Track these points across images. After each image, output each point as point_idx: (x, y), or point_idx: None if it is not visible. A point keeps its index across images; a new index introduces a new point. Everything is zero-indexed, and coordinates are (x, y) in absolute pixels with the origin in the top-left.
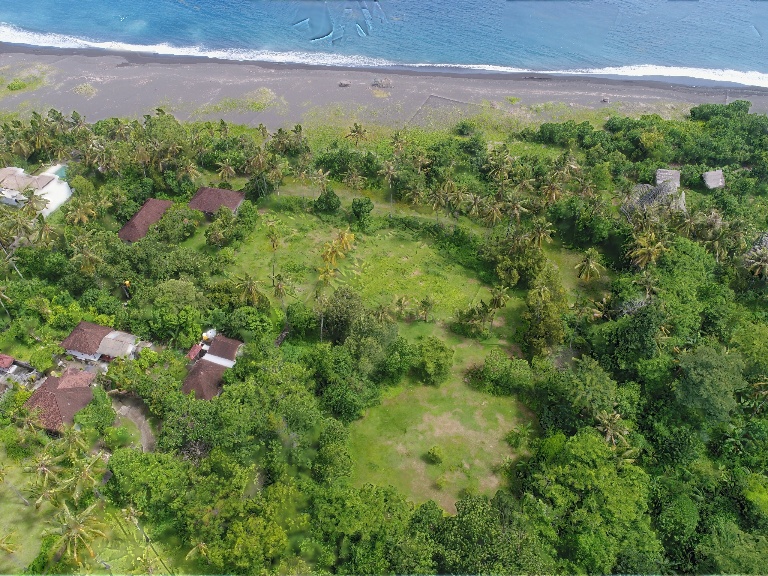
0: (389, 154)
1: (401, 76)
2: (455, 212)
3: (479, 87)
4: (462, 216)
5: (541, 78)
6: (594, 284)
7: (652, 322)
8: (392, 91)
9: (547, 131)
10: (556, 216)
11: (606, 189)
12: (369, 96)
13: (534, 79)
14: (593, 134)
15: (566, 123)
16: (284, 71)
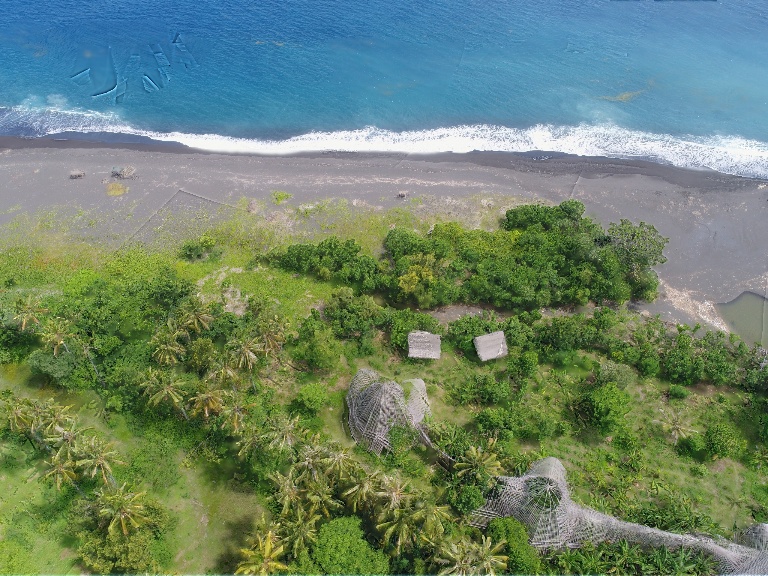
0: (75, 296)
1: (163, 156)
2: (104, 411)
3: (251, 173)
4: (118, 415)
5: (346, 152)
6: (245, 558)
7: None
8: (133, 185)
9: (293, 257)
10: (221, 433)
11: (331, 366)
12: (99, 194)
13: (335, 154)
14: (355, 260)
15: (324, 242)
16: (21, 152)
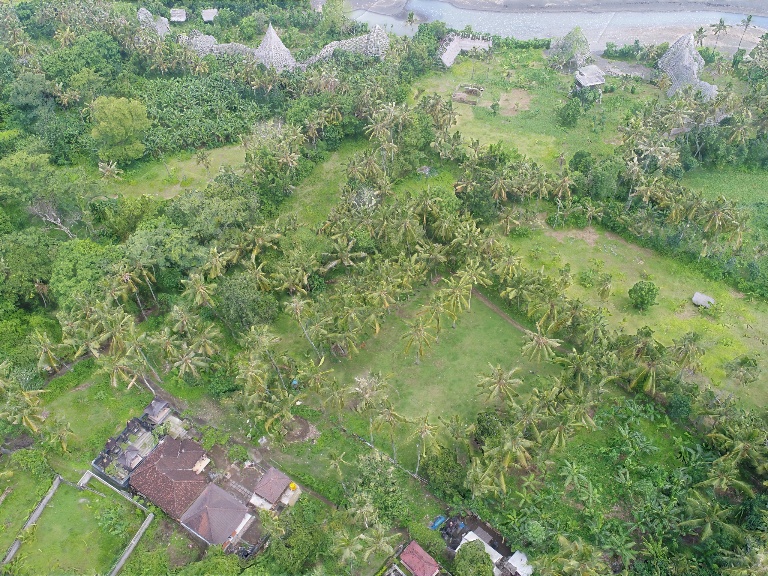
0: None
1: None
2: None
3: None
4: None
5: None
6: None
7: (0, 59)
8: None
9: None
10: None
11: None
12: None
13: None
14: None
15: None
16: None
